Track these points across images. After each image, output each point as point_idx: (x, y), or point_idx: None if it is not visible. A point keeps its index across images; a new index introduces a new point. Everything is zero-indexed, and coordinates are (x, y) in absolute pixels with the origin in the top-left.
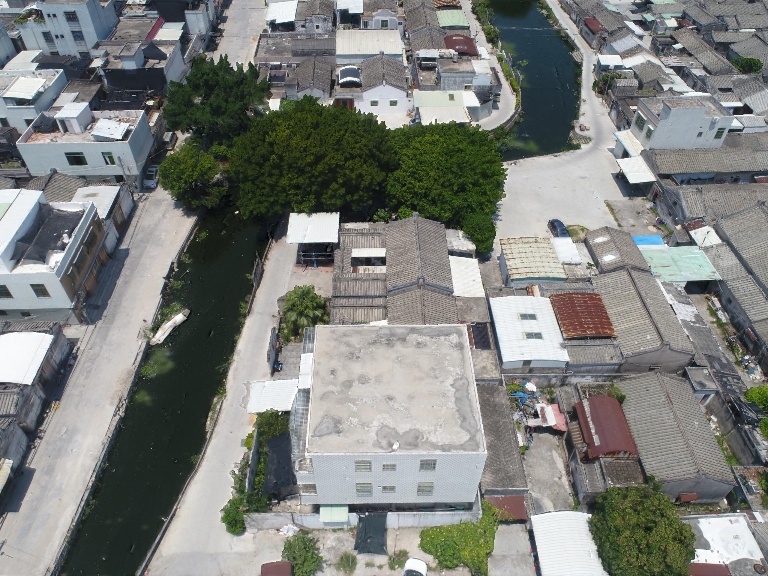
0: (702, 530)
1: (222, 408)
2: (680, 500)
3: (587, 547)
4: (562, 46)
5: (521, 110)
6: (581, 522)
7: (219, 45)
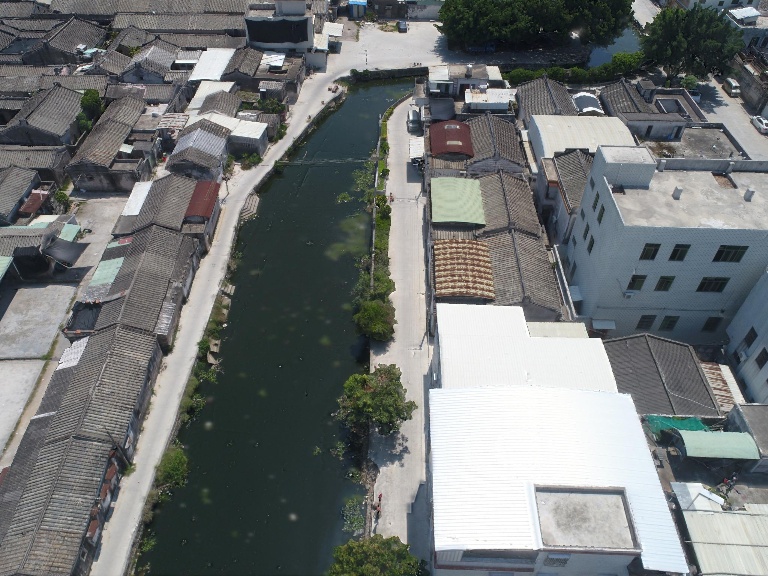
0: None
1: None
2: None
3: None
4: None
5: None
6: None
7: None
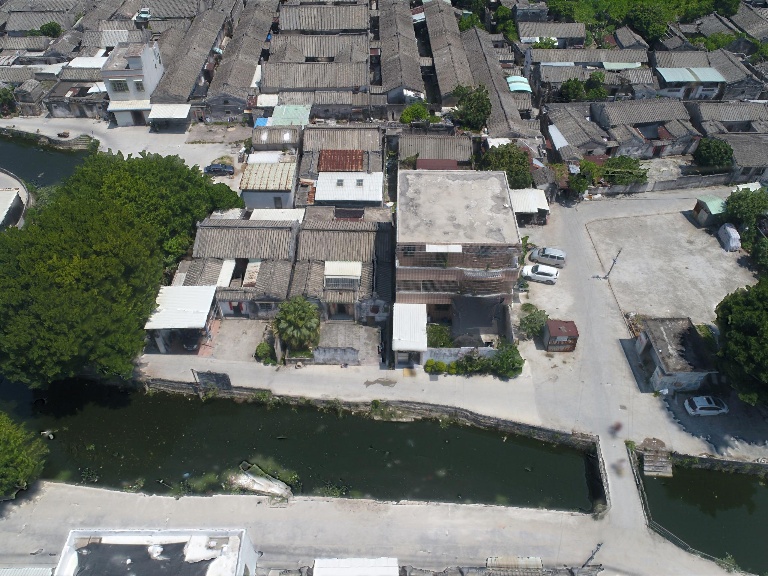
0: None
1: None
2: (474, 161)
3: (512, 191)
4: None
5: None
6: None
7: None
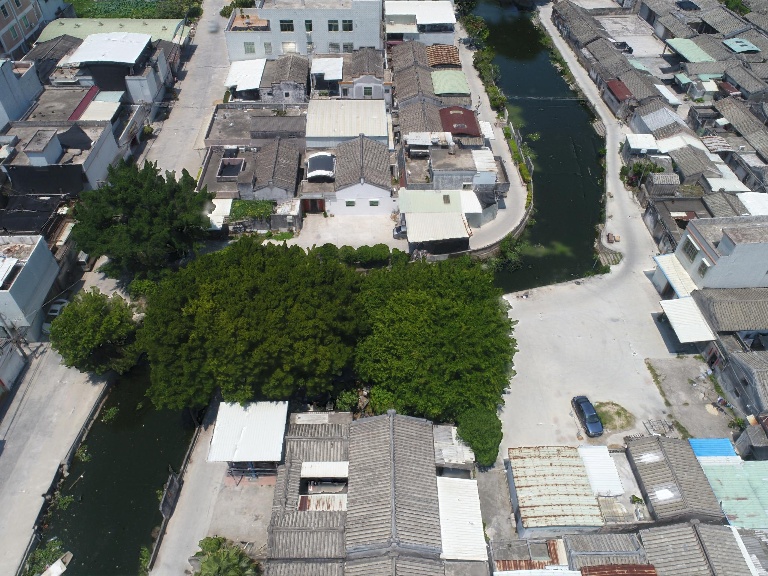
0: None
1: None
2: None
3: None
4: (580, 110)
5: (533, 207)
6: None
7: (171, 112)
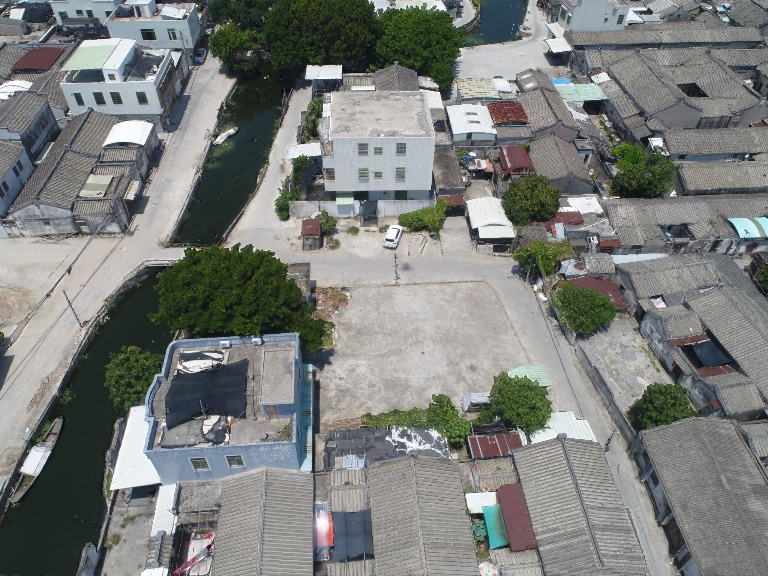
0: (569, 202)
1: (267, 170)
2: None
3: (499, 210)
4: None
5: (480, 19)
6: (496, 201)
7: None
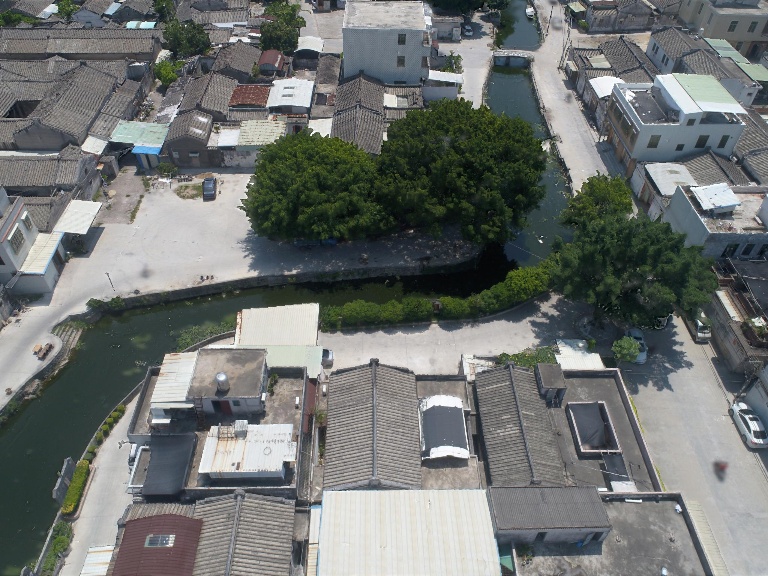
0: None
1: None
2: None
3: None
4: None
5: None
6: None
7: None
